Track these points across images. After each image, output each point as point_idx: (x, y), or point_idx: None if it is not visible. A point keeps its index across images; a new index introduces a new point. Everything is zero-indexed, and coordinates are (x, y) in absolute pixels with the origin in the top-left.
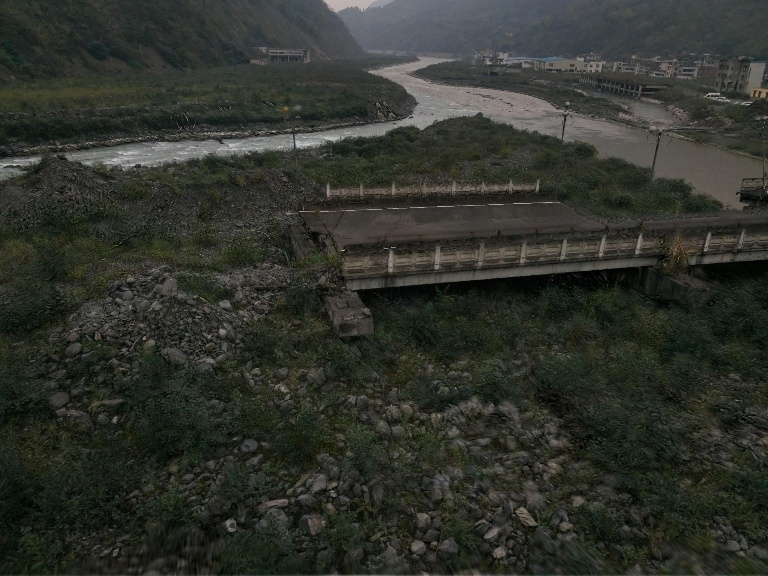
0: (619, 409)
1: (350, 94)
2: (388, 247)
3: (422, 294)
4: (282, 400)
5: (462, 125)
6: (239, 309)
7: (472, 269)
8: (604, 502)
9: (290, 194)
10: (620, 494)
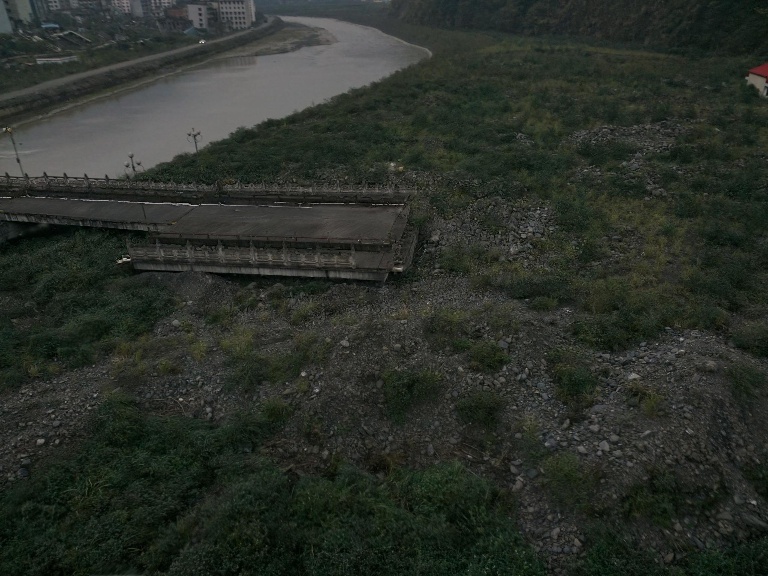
0: None
1: None
2: None
3: None
4: None
5: None
6: None
7: None
8: None
9: None
10: None
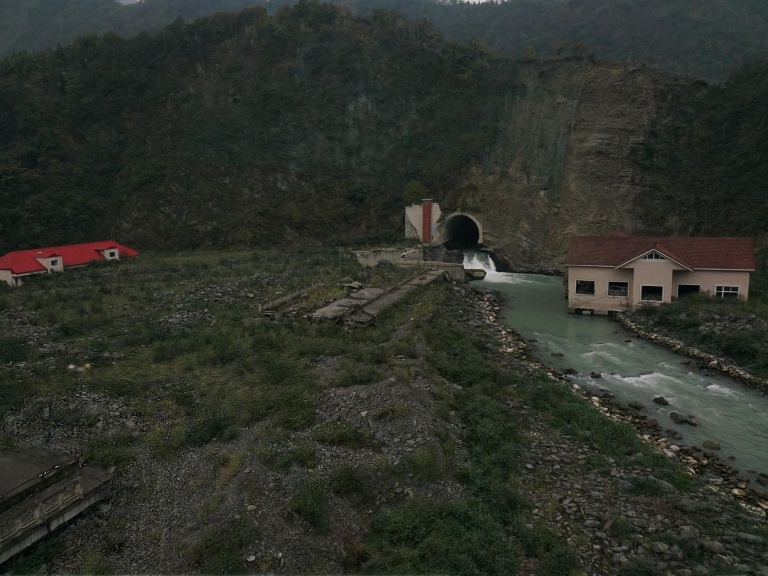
0: None
1: None
2: None
3: None
4: None
5: None
6: None
7: None
8: None
9: None
10: None
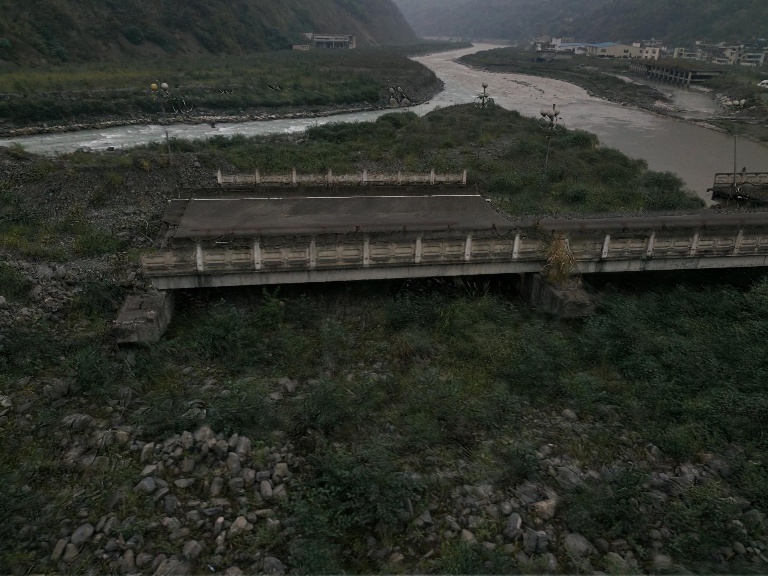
0: (386, 449)
1: (366, 79)
2: (228, 241)
3: (246, 296)
4: None
5: (465, 111)
6: (29, 306)
7: (304, 270)
8: (275, 575)
9: (201, 180)
10: (303, 566)
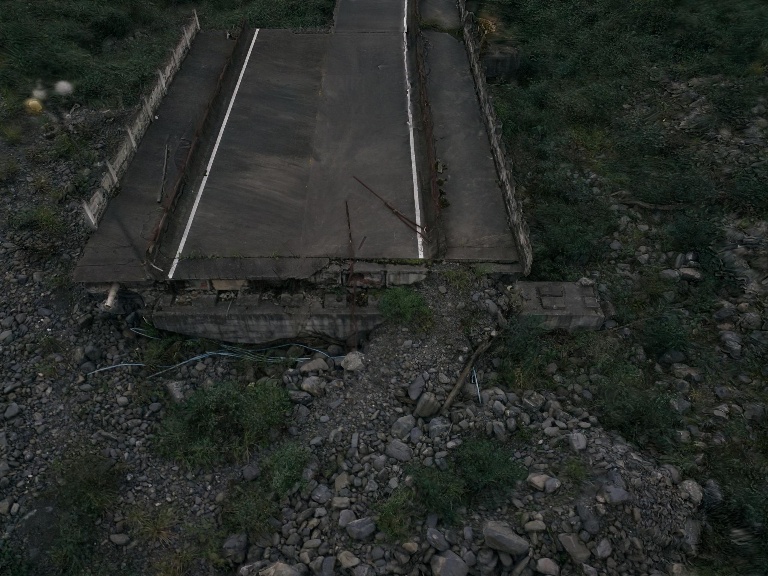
0: None
1: None
2: (414, 208)
3: None
4: (742, 415)
5: None
6: (530, 434)
7: None
8: None
9: None
10: None
